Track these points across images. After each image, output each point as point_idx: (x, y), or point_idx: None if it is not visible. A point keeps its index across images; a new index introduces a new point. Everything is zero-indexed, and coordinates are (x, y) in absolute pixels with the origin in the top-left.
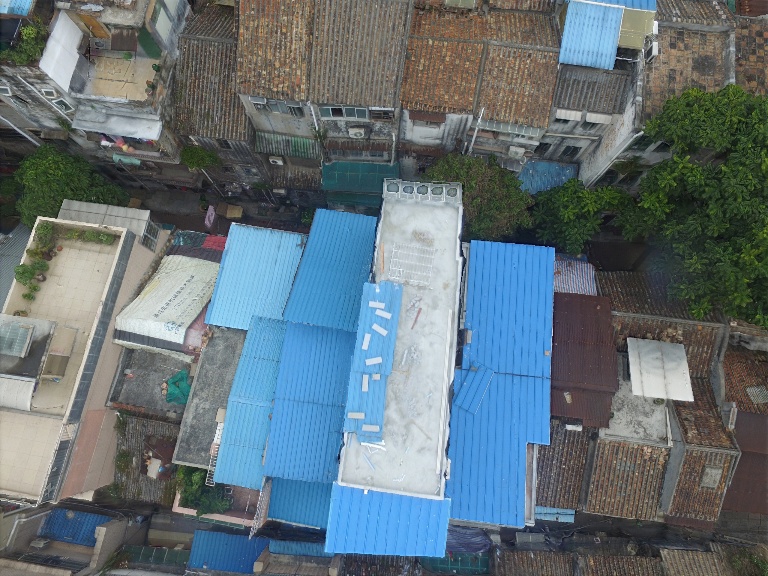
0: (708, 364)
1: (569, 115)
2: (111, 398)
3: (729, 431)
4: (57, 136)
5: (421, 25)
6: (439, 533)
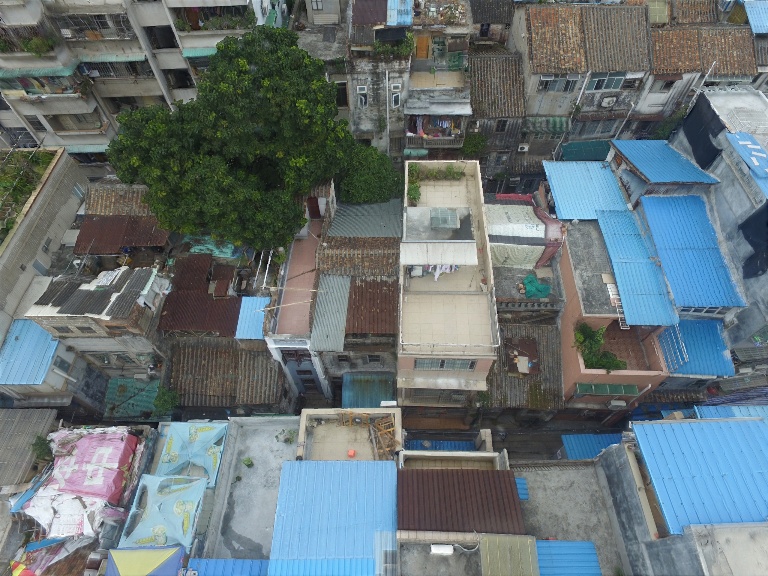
0: None
1: (764, 69)
2: None
3: None
4: (366, 137)
5: None
6: None
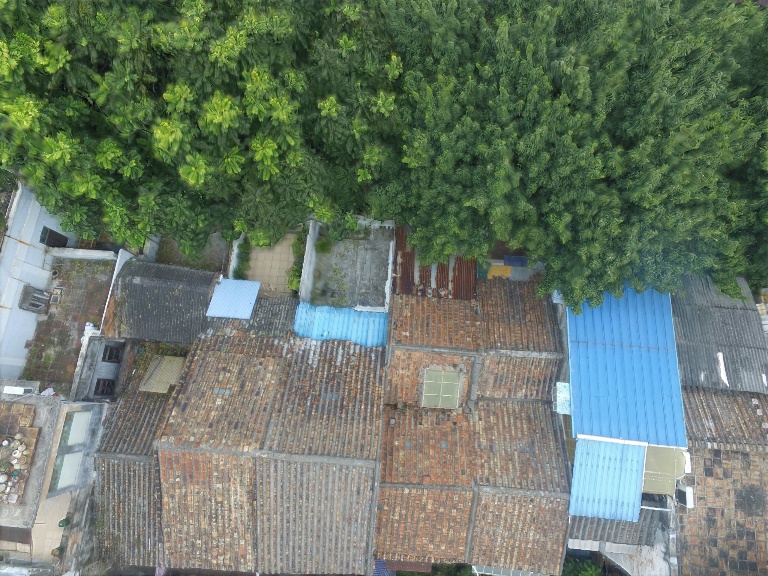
0: None
1: (584, 544)
2: None
3: None
4: None
5: (393, 453)
6: None
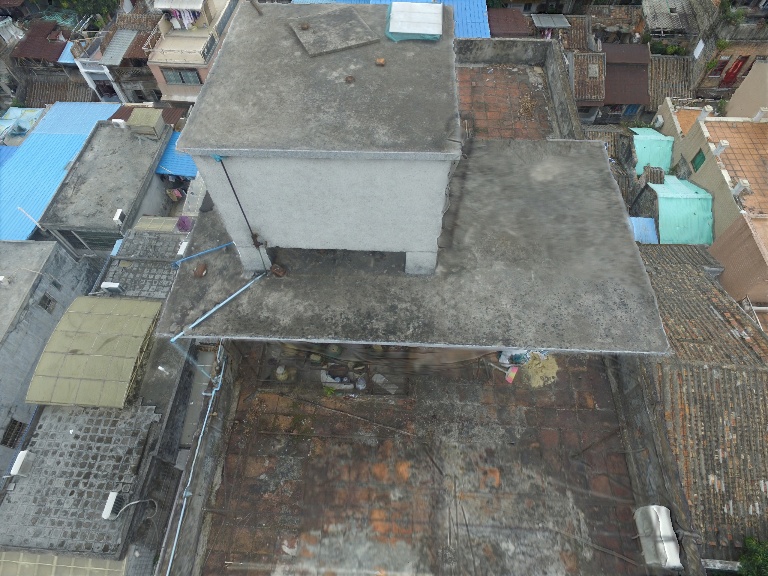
0: (585, 40)
1: None
2: None
3: (599, 52)
4: None
5: None
6: None
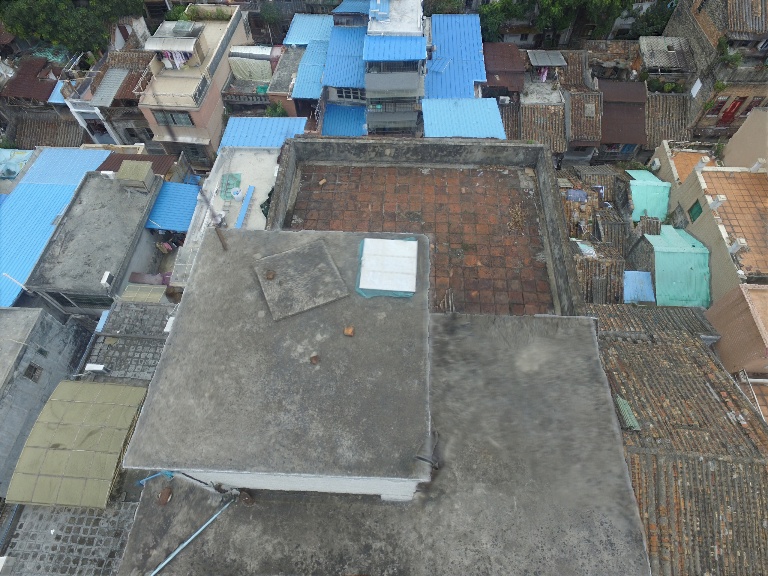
0: (582, 76)
1: None
2: (224, 90)
3: (596, 90)
4: (189, 1)
5: None
6: (422, 49)
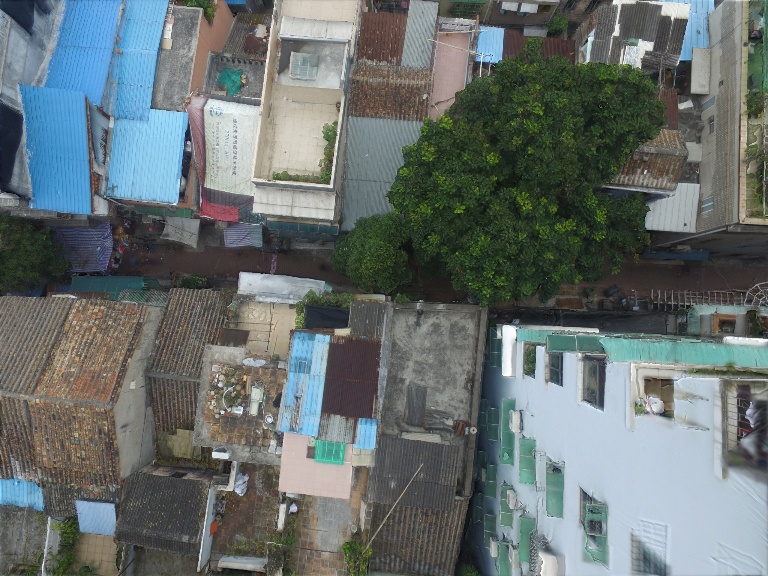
0: None
1: None
2: None
3: None
4: None
5: None
6: None
